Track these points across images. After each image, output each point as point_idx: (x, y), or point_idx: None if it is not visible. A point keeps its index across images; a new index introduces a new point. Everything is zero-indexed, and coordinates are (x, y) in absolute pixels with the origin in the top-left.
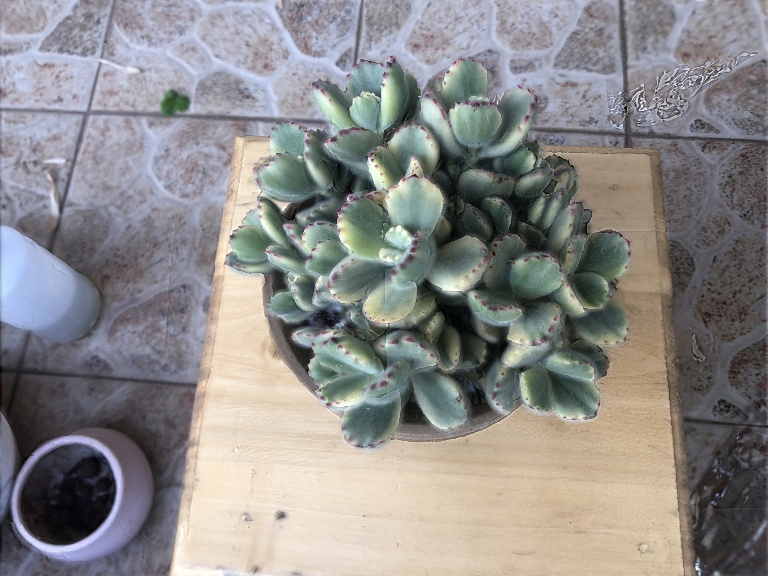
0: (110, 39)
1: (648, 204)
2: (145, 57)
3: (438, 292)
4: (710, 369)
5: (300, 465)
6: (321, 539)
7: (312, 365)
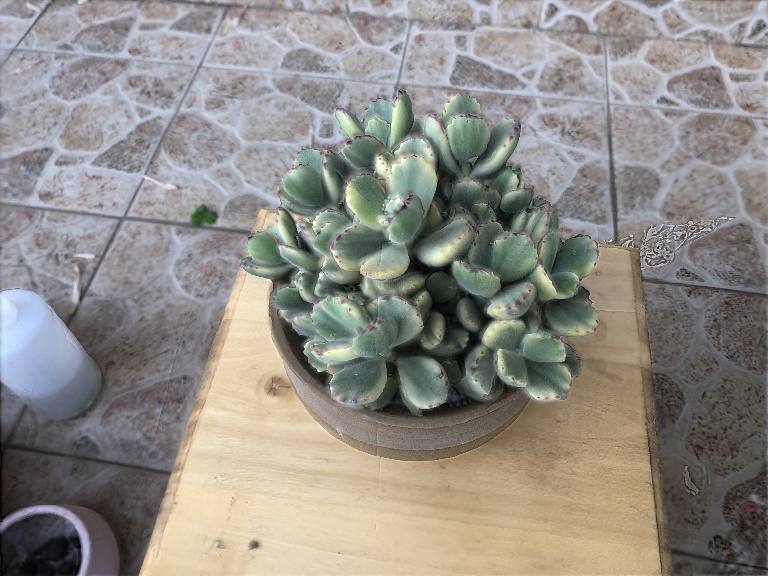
0: (156, 161)
1: (628, 290)
2: (184, 178)
3: (428, 273)
4: (704, 503)
5: (280, 497)
6: (292, 573)
7: (308, 345)
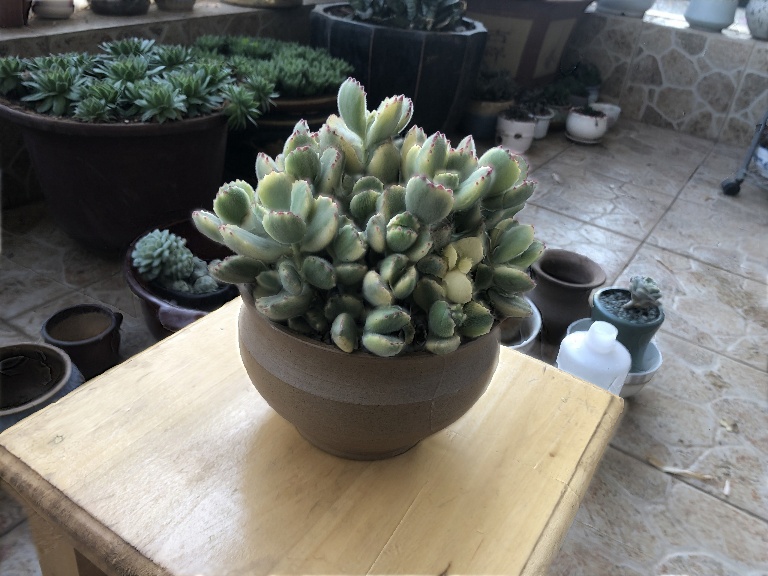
0: None
1: None
2: None
3: None
4: None
5: None
6: None
7: None
